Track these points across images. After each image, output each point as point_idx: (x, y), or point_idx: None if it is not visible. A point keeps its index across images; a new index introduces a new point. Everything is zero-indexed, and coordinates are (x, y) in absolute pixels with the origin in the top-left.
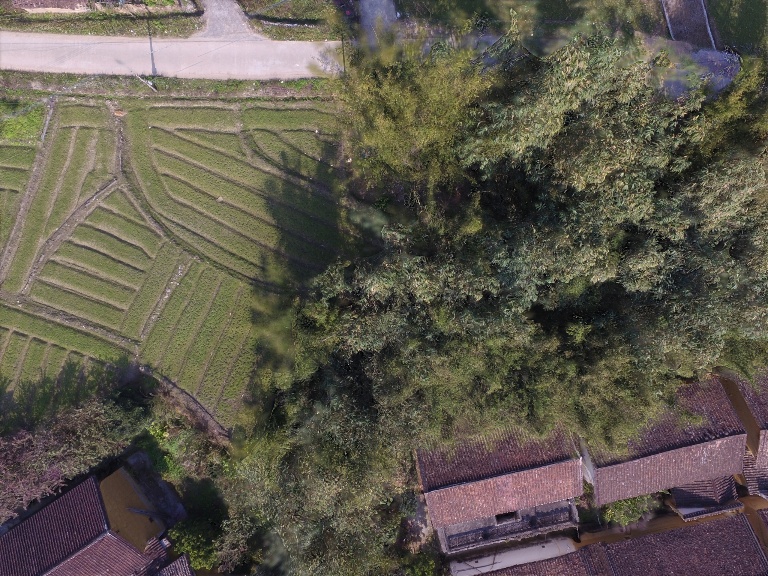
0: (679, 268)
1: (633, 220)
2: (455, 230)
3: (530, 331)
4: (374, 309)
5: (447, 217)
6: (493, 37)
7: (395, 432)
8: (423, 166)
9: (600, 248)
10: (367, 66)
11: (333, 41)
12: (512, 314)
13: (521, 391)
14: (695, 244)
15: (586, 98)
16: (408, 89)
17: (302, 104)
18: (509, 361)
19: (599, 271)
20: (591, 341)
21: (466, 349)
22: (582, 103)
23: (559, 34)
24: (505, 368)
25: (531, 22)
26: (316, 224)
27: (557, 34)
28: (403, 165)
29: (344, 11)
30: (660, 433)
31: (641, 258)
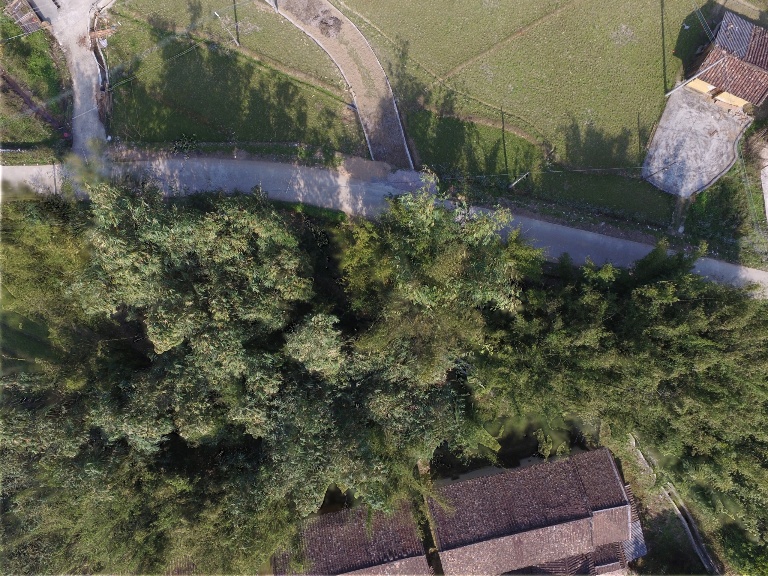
0: (291, 415)
1: (234, 373)
2: (66, 383)
3: (108, 492)
4: (4, 454)
5: (83, 361)
6: (198, 159)
7: (32, 571)
8: (62, 311)
9: (194, 404)
10: (77, 189)
11: (44, 165)
12: (94, 474)
13: (128, 540)
14: (303, 393)
15: (153, 269)
16: (5, 254)
17: (17, 225)
18: (129, 506)
19: (189, 428)
20: (209, 486)
21: (66, 502)
22: (151, 273)
23: (261, 156)
24: (124, 513)
25: (236, 144)
26: (29, 342)
27: (259, 156)
28: (43, 310)
29: (62, 133)
30: (344, 553)
31: (233, 413)
